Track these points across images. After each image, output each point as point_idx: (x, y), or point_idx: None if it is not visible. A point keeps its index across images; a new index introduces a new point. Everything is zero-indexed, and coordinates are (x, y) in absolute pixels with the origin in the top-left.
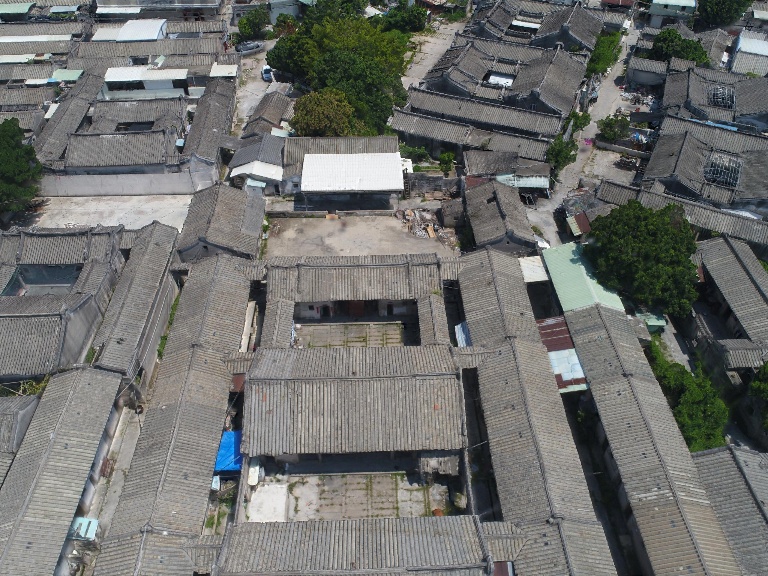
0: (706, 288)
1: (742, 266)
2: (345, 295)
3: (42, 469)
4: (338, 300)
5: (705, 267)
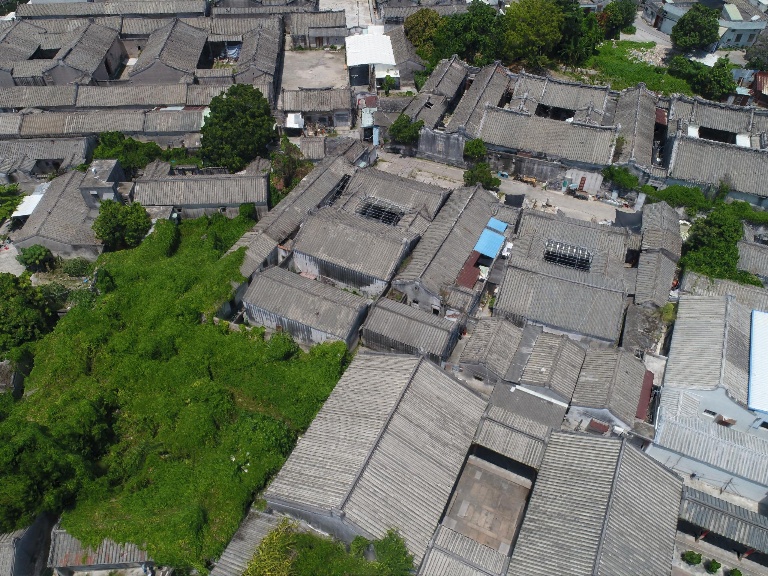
0: None
1: None
2: None
3: (158, 1)
4: None
5: None
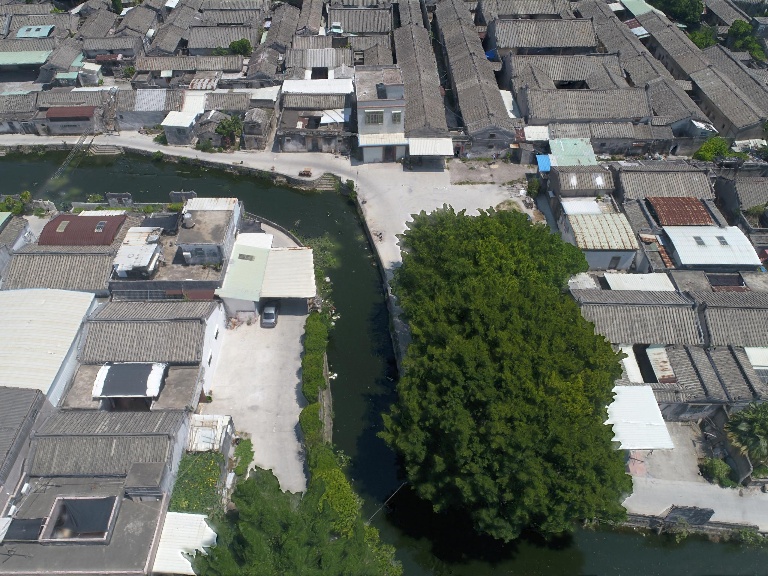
0: (708, 19)
1: (726, 2)
2: (522, 12)
3: None
4: (519, 14)
5: (707, 7)
